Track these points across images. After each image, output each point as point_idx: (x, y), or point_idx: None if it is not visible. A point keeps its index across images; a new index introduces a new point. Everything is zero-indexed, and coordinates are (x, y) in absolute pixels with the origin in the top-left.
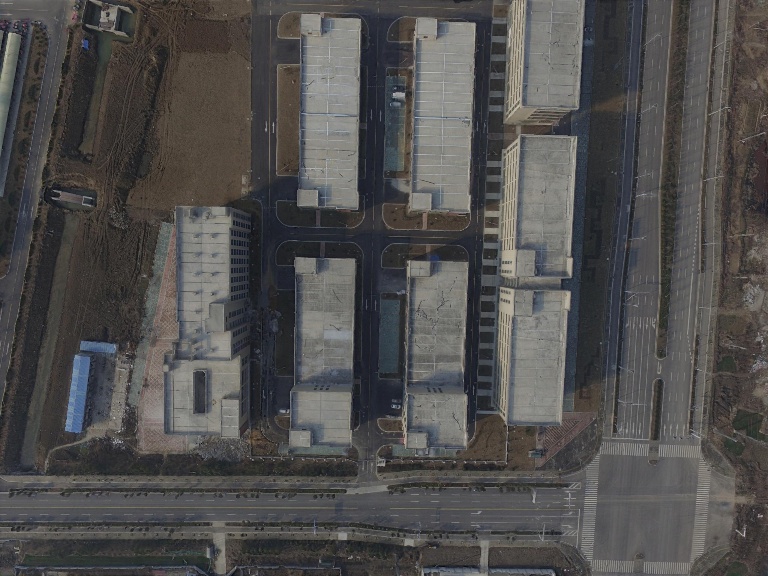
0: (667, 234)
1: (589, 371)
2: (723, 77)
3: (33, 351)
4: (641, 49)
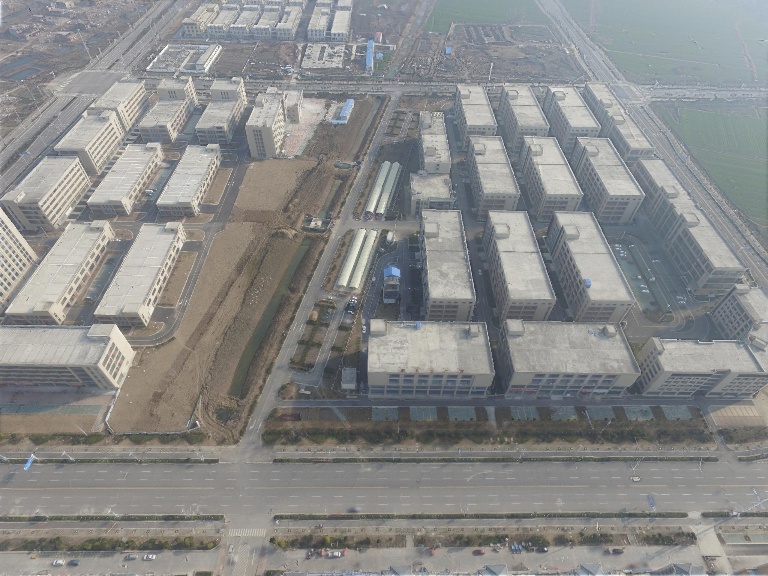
0: (24, 147)
1: None
2: None
3: None
4: None
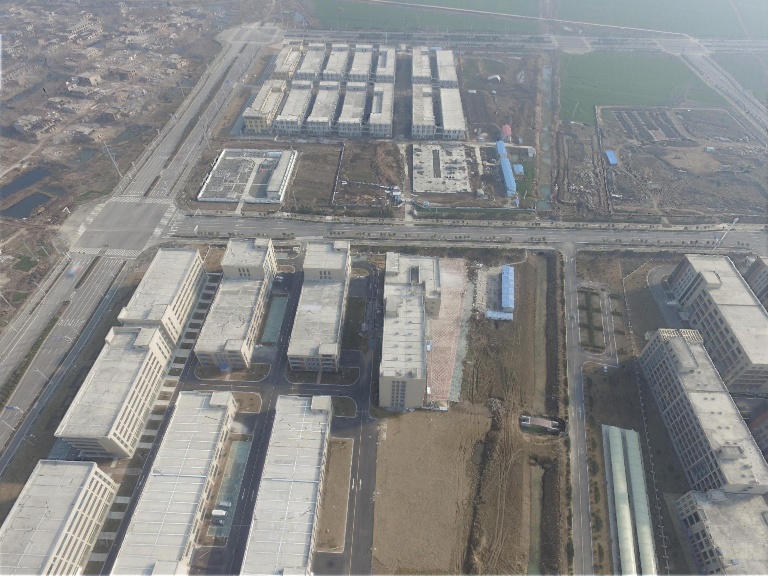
0: (13, 382)
1: (128, 294)
2: None
3: (551, 317)
4: None
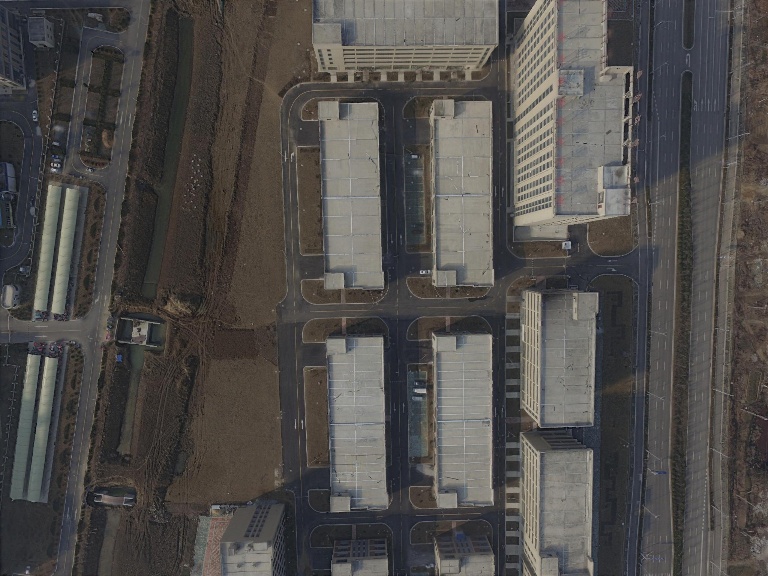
0: (678, 500)
1: None
2: (725, 353)
3: None
4: (647, 333)
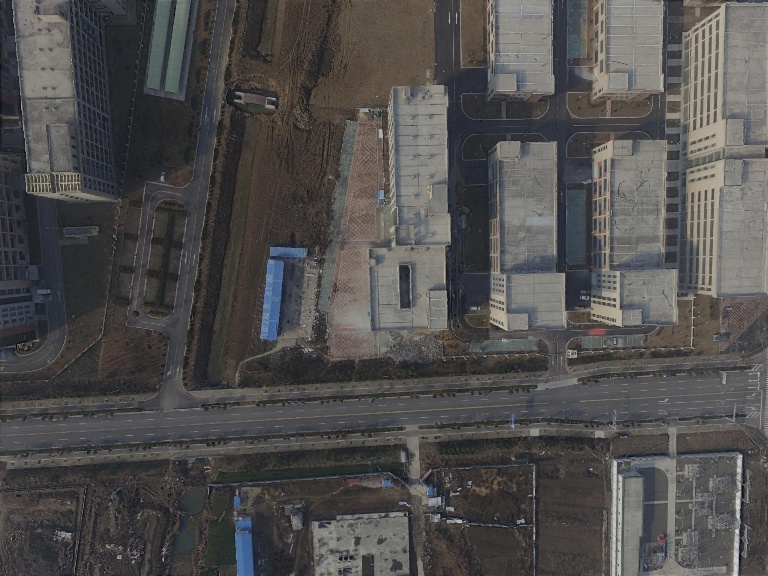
0: None
1: None
2: None
3: (218, 262)
4: None
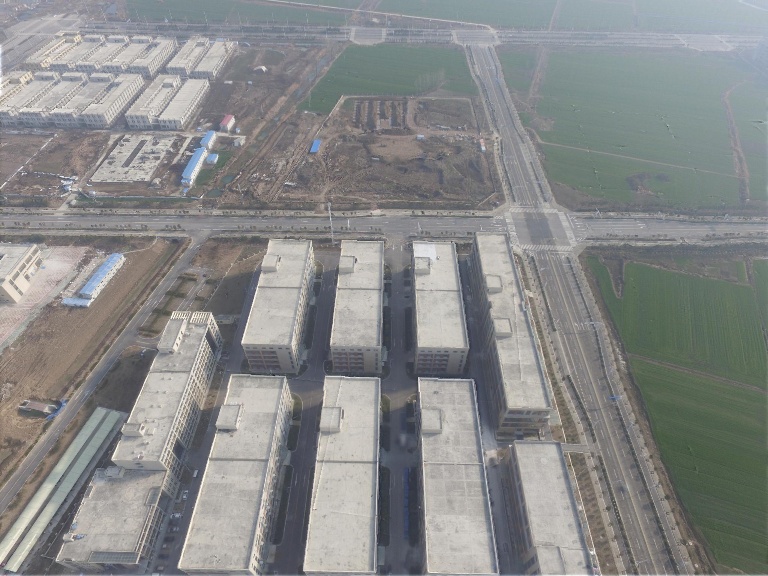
0: None
1: None
2: None
3: None
4: None
